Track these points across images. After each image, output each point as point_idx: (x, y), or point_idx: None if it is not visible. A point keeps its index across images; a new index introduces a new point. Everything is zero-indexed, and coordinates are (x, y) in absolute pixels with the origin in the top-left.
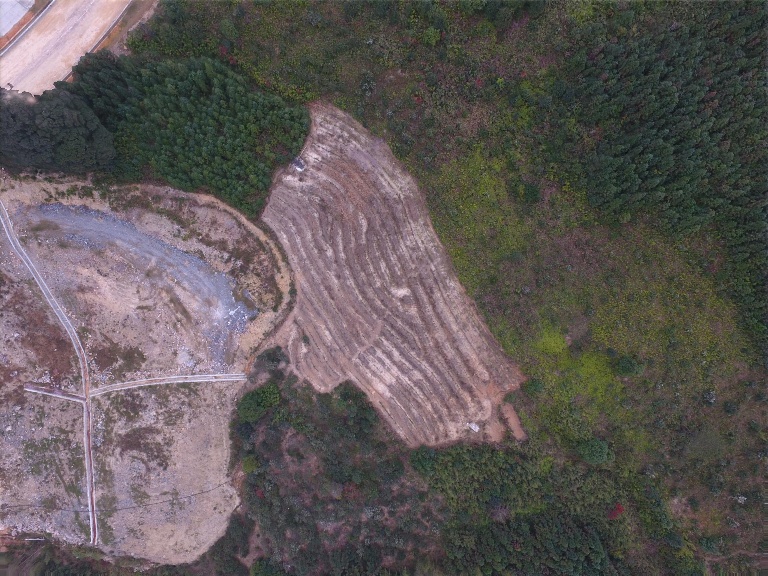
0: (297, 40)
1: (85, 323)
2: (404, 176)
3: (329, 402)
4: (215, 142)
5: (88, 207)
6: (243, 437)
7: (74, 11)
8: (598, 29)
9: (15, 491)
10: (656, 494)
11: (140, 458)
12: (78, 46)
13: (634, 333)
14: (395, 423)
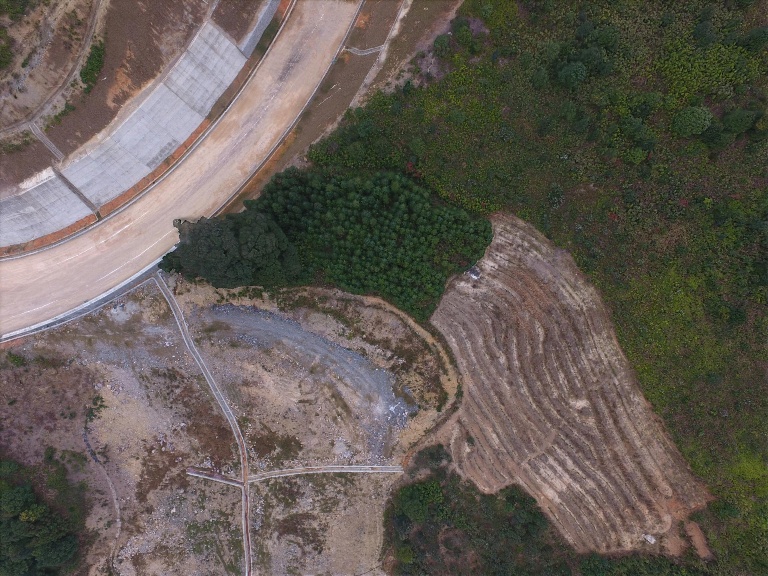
0: (485, 154)
1: (246, 413)
2: (587, 287)
3: (494, 504)
4: (394, 253)
5: (257, 307)
6: None
7: (248, 117)
8: None
9: (177, 567)
10: None
11: (296, 542)
12: (253, 153)
13: None
14: (563, 528)
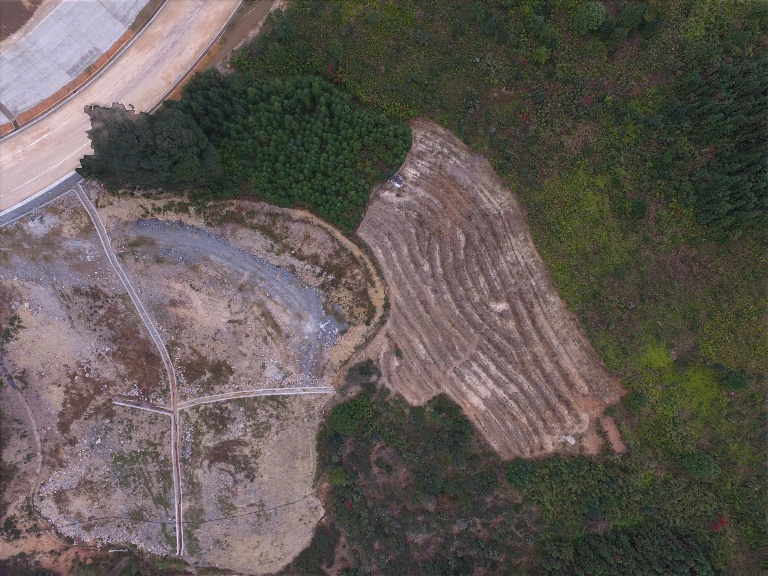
0: (402, 58)
1: (175, 337)
2: (504, 192)
3: (423, 415)
4: (317, 159)
5: (183, 223)
6: (333, 449)
7: (173, 29)
8: (713, 49)
9: (103, 503)
10: (760, 507)
11: (228, 470)
12: (177, 64)
13: (743, 348)
14: (489, 436)
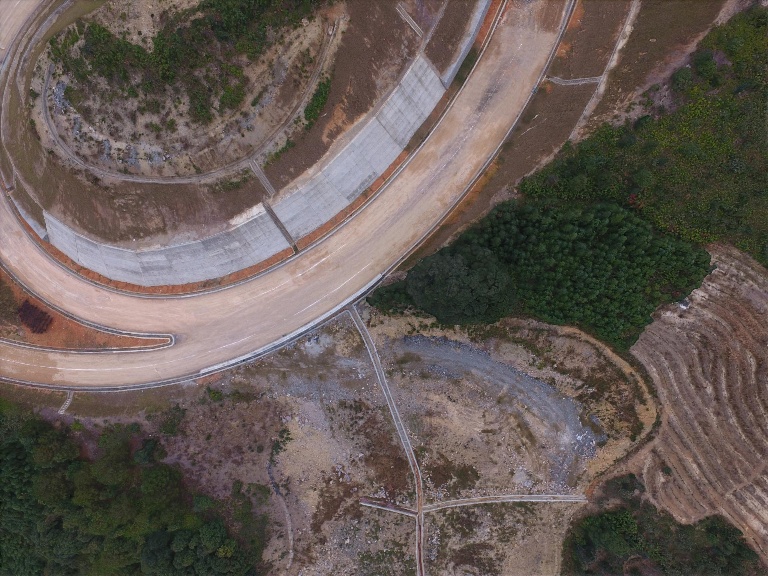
0: (710, 185)
1: (424, 443)
2: None
3: None
4: (606, 284)
5: (447, 338)
6: None
7: (447, 148)
8: None
9: None
10: None
11: (472, 572)
12: (453, 184)
13: None
14: (767, 559)
